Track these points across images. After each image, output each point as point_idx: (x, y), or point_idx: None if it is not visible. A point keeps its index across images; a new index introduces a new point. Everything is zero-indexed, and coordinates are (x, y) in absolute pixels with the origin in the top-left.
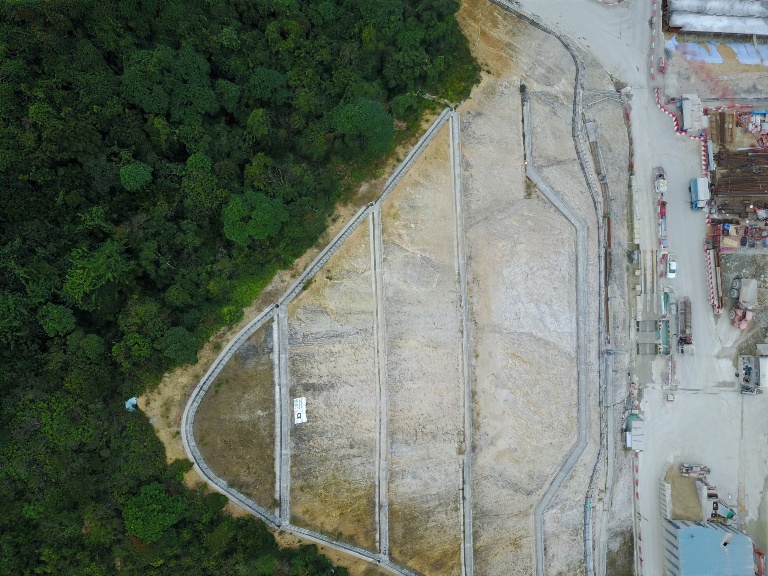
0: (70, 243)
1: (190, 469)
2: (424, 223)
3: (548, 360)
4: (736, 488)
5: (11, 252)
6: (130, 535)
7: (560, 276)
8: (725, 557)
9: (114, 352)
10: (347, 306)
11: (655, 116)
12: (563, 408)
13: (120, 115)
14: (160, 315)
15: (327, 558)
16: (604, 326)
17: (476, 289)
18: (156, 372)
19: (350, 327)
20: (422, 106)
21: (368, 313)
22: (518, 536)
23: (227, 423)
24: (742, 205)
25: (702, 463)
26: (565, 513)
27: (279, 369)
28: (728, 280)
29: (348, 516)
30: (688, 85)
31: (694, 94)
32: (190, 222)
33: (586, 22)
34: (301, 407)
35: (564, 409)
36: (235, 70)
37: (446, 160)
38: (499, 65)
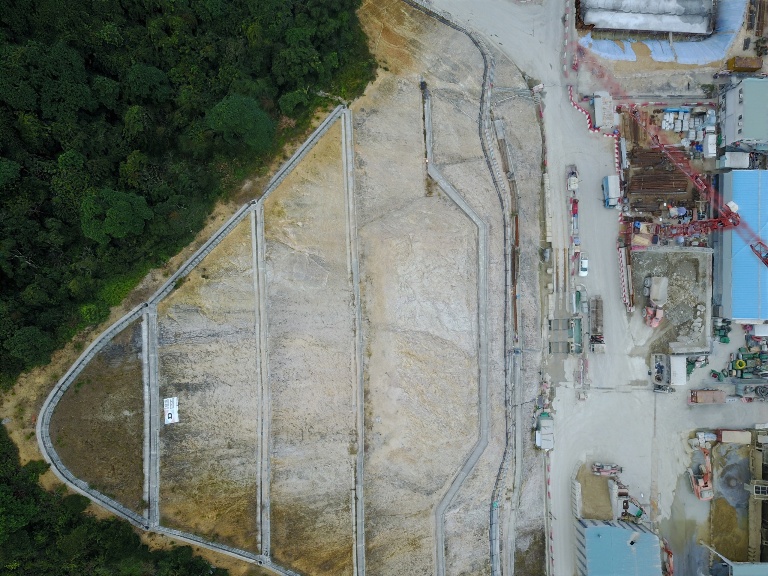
0: None
1: (47, 470)
2: (313, 221)
3: (445, 359)
4: (649, 487)
5: None
6: None
7: (458, 274)
8: (632, 556)
9: None
10: (226, 305)
11: (568, 114)
12: (461, 407)
13: None
14: (11, 314)
15: (204, 559)
16: (512, 325)
17: (369, 288)
18: (10, 372)
19: (229, 326)
20: (314, 103)
21: (249, 312)
22: (417, 536)
23: (89, 424)
24: (655, 203)
25: (614, 462)
26: (469, 513)
27: (149, 369)
28: (640, 278)
29: (226, 517)
30: (602, 83)
31: (606, 92)
32: (55, 220)
33: (498, 19)
34: (172, 407)
35: (462, 408)
36: (118, 67)
37: (338, 158)
38: (399, 62)
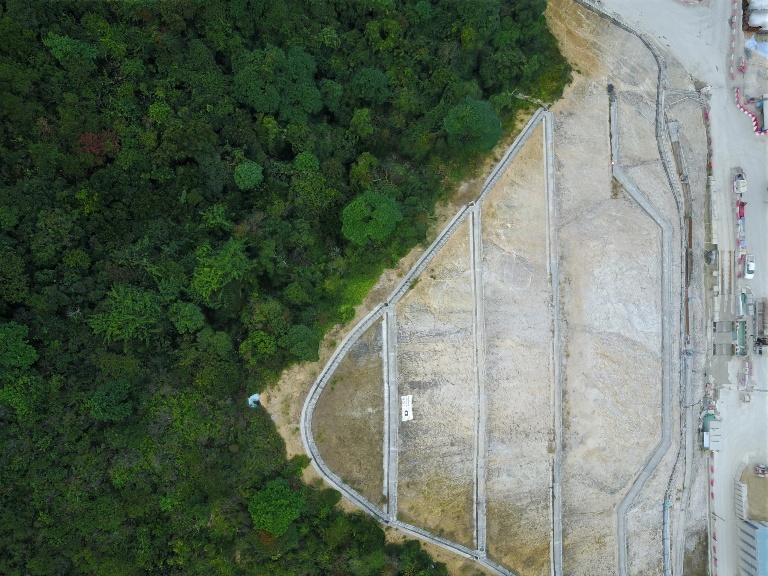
0: (192, 241)
1: (308, 465)
2: (519, 223)
3: (636, 360)
4: None
5: (142, 250)
6: (259, 529)
7: (648, 276)
8: None
9: (242, 349)
10: (449, 305)
11: (734, 116)
12: (650, 408)
13: (230, 114)
14: (283, 313)
15: (428, 554)
16: (684, 326)
17: (567, 289)
18: (277, 369)
19: (452, 326)
20: (516, 106)
21: (468, 312)
22: (602, 534)
23: (341, 420)
24: None
25: None
26: (645, 512)
27: (387, 367)
28: None
29: (449, 513)
30: (767, 85)
31: None
32: (303, 221)
33: (666, 21)
34: (408, 405)
35: (651, 409)
36: (335, 69)
37: (539, 160)
38: (587, 65)
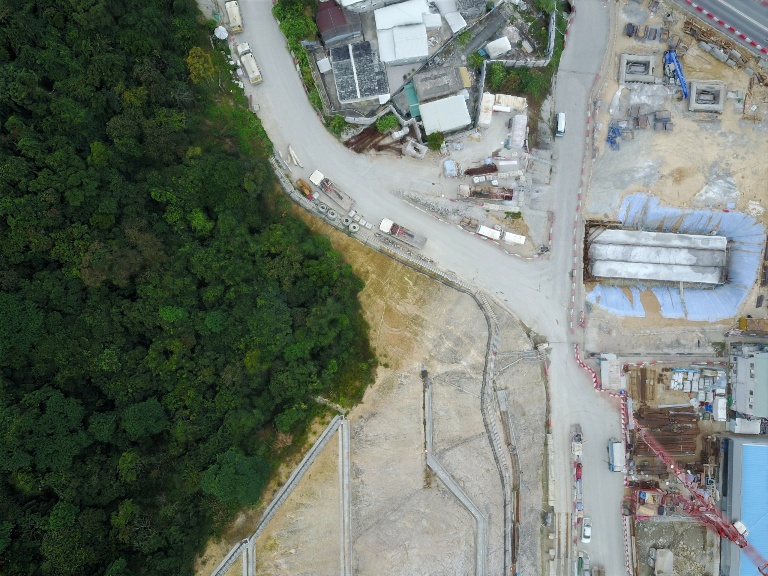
0: None
1: None
2: (306, 545)
3: None
4: None
5: None
6: None
7: None
8: None
9: None
10: None
11: (574, 371)
12: None
13: None
14: None
15: None
16: None
17: None
18: None
19: None
20: (311, 415)
21: None
22: None
23: None
24: (662, 465)
25: None
26: None
27: None
28: (645, 547)
29: None
30: (609, 339)
31: (613, 354)
32: None
33: (504, 276)
34: None
35: None
36: (115, 393)
37: (334, 471)
38: (400, 351)
